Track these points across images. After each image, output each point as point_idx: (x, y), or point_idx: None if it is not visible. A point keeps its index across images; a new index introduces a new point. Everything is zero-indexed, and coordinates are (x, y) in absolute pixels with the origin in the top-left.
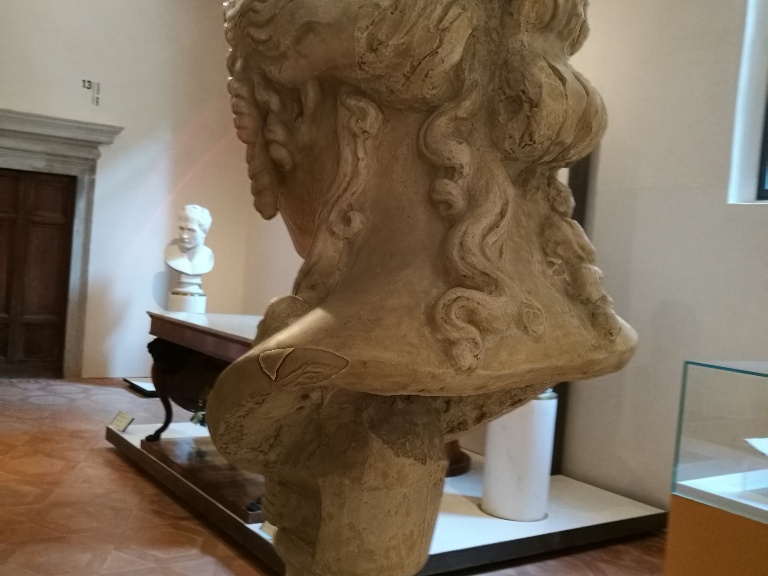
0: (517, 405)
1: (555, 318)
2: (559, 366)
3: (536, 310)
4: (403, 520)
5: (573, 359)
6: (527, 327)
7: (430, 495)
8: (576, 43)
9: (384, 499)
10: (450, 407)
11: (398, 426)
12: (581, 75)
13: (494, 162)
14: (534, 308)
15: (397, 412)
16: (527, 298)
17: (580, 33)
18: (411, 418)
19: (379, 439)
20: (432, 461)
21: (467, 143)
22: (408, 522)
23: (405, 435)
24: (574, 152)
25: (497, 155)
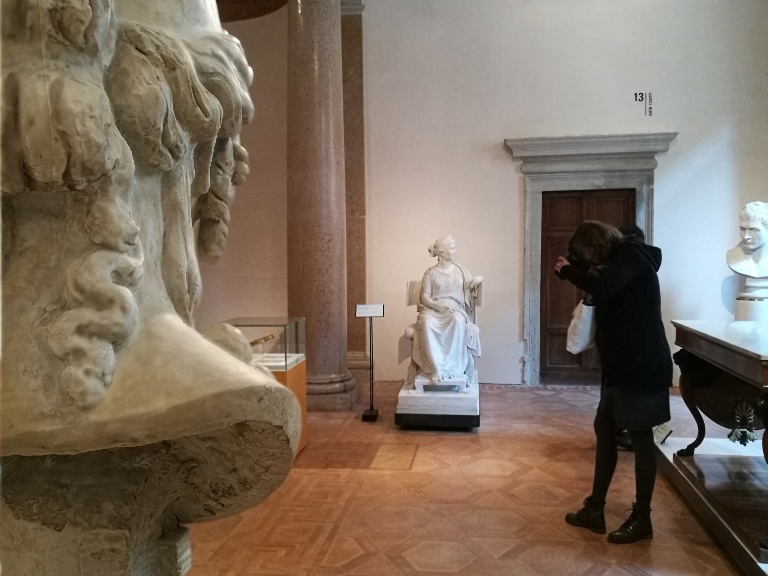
0: (271, 472)
1: (7, 379)
2: None
3: None
4: None
5: None
6: None
7: (86, 566)
8: (73, 36)
9: (18, 561)
10: (181, 468)
11: (35, 485)
12: (26, 81)
13: None
14: None
15: (41, 470)
16: None
17: (65, 24)
18: (58, 478)
19: (2, 497)
20: (78, 528)
21: None
22: None
23: (37, 496)
24: (43, 174)
25: None
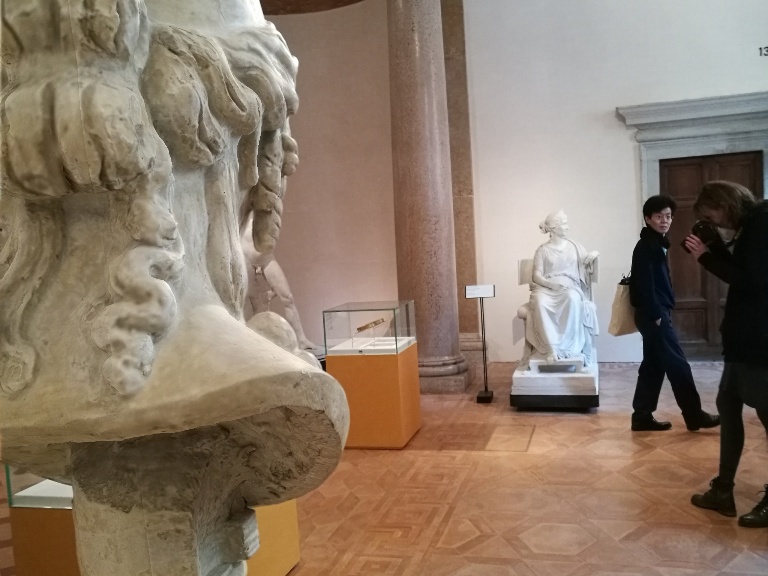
0: None
1: (58, 371)
2: (30, 427)
3: (20, 364)
4: (115, 565)
5: (52, 419)
6: (1, 384)
7: (154, 545)
8: (104, 43)
9: (93, 541)
10: (240, 452)
11: (104, 470)
12: (61, 89)
13: (19, 207)
14: (20, 362)
15: (110, 456)
16: (17, 351)
17: (95, 32)
18: (125, 463)
19: (76, 481)
20: (144, 510)
21: (5, 193)
22: (122, 569)
23: (106, 480)
24: (81, 177)
25: (23, 199)
